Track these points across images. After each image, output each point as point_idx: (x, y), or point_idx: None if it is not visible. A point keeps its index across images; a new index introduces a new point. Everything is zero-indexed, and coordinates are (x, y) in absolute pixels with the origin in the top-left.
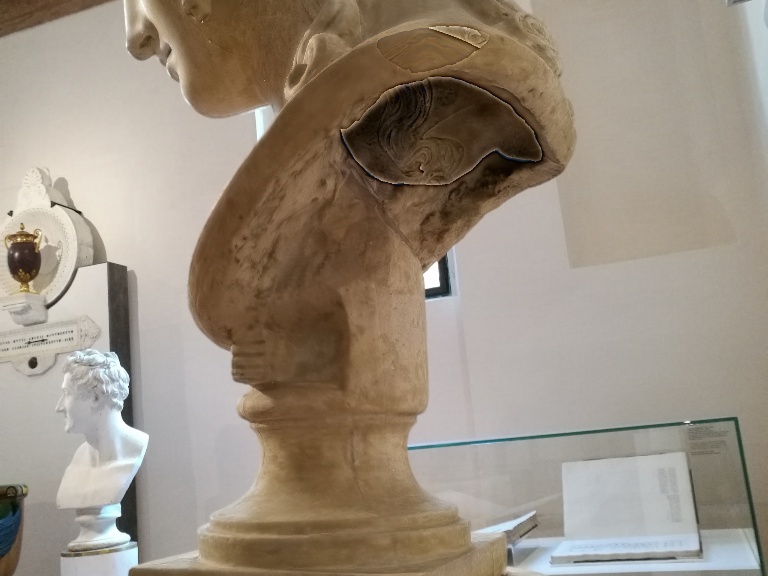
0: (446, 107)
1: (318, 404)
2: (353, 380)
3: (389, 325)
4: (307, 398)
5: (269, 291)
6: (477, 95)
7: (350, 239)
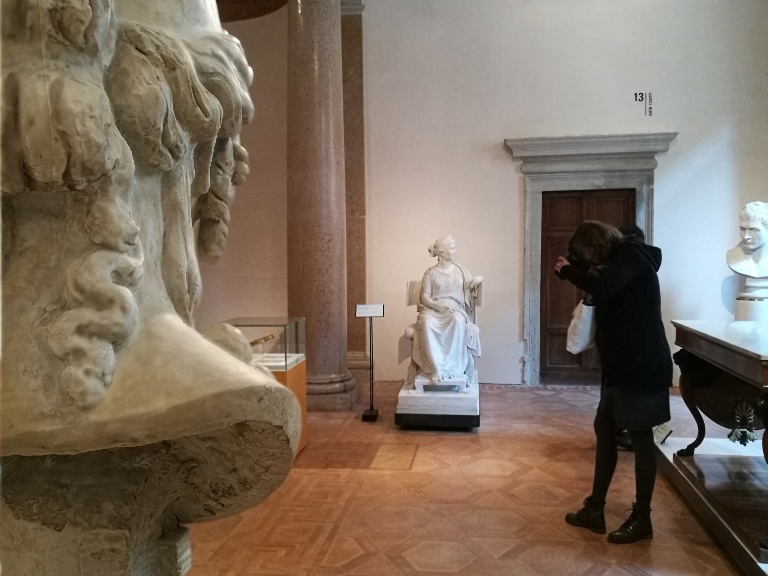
0: (172, 309)
1: None
2: None
3: (3, 574)
4: None
5: None
6: (153, 308)
7: None
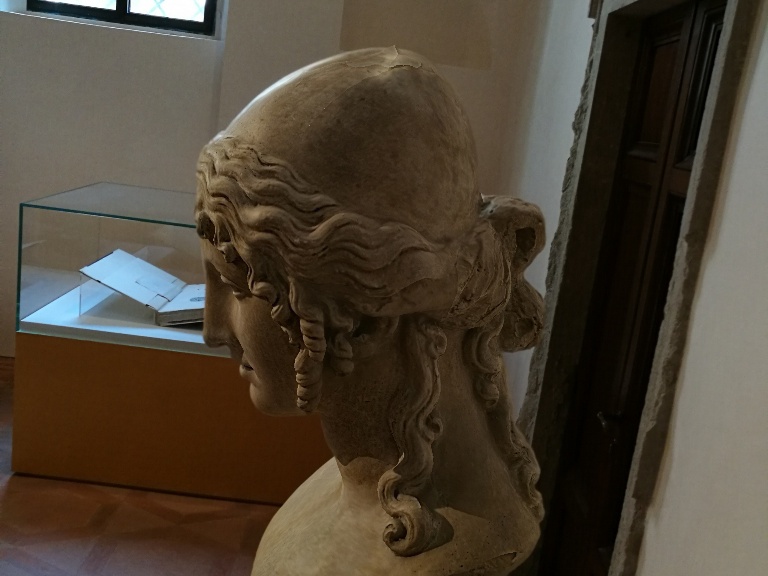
0: None
1: None
2: None
3: None
4: None
5: None
6: None
7: None
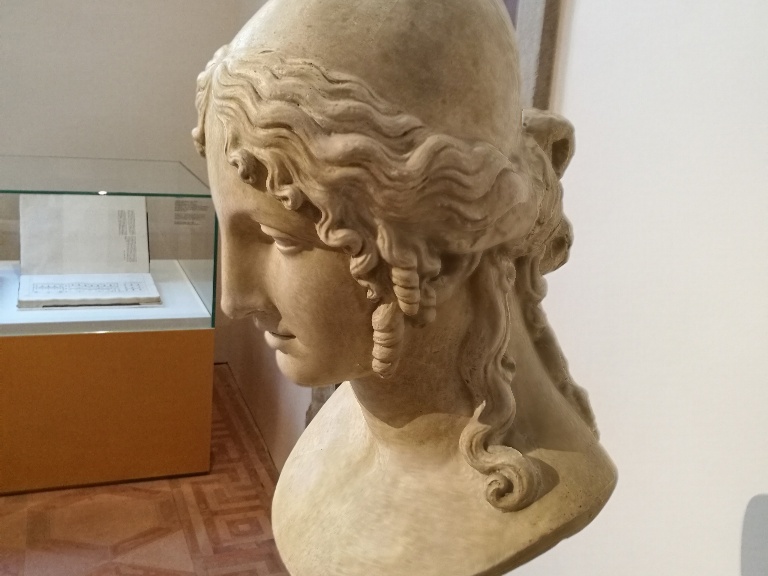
0: None
1: None
2: None
3: None
4: None
5: None
6: None
7: None
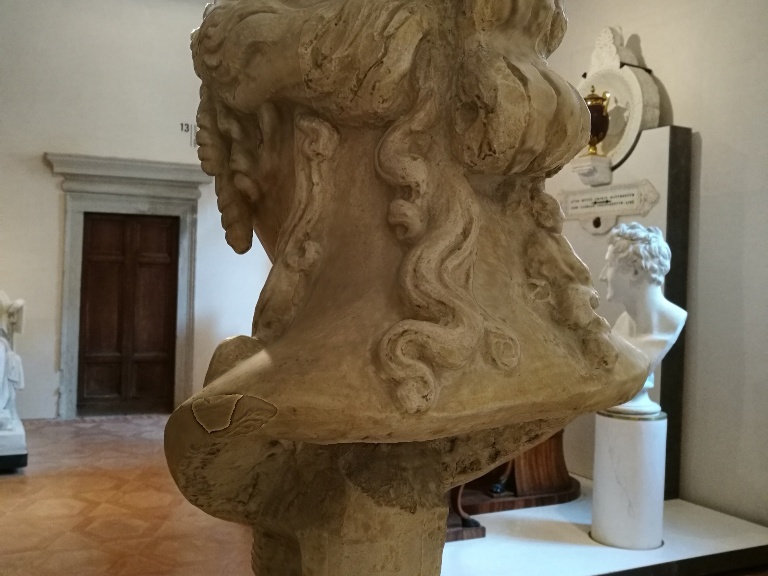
0: None
1: None
2: None
3: (339, 572)
4: None
5: (256, 514)
6: None
7: (316, 484)
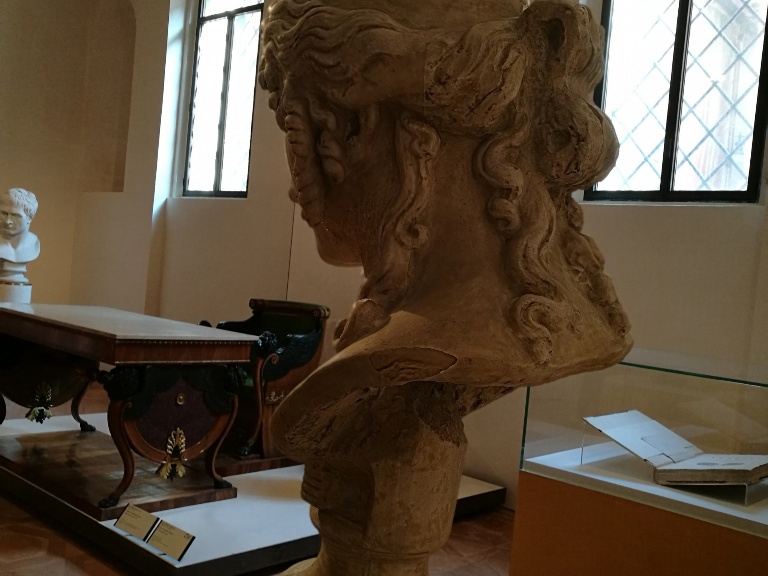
0: None
1: (345, 540)
2: (371, 530)
3: (407, 494)
4: (339, 533)
5: (325, 452)
6: None
7: (390, 424)
